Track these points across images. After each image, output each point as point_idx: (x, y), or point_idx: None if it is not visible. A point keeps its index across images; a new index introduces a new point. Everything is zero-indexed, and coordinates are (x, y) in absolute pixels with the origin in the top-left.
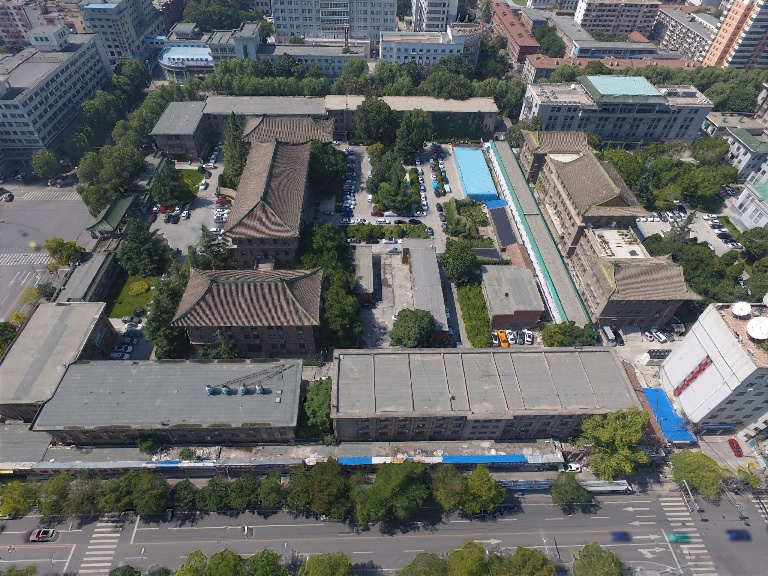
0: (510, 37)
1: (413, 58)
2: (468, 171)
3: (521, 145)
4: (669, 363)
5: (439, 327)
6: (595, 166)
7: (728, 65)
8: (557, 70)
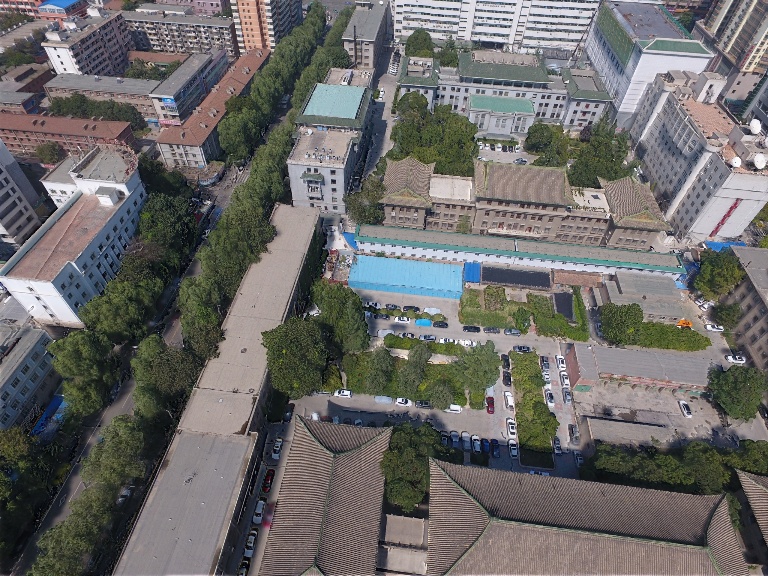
0: (65, 139)
1: (106, 257)
2: (410, 279)
3: (382, 214)
4: (698, 226)
5: (718, 368)
6: (513, 169)
7: (274, 38)
8: (228, 131)
